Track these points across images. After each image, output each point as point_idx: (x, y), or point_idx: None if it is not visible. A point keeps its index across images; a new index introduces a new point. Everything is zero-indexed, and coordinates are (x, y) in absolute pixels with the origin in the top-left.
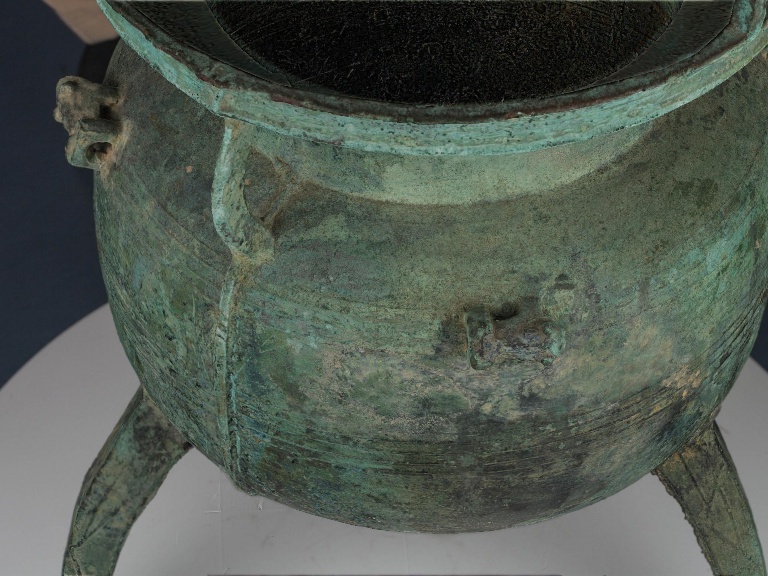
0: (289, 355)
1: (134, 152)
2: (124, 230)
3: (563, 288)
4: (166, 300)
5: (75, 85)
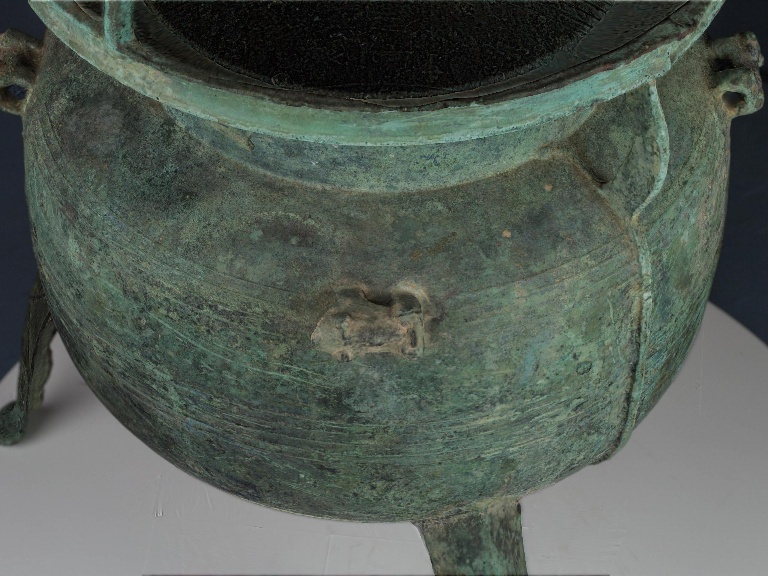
0: (684, 251)
1: (446, 287)
2: (496, 346)
3: None
4: (578, 340)
5: None
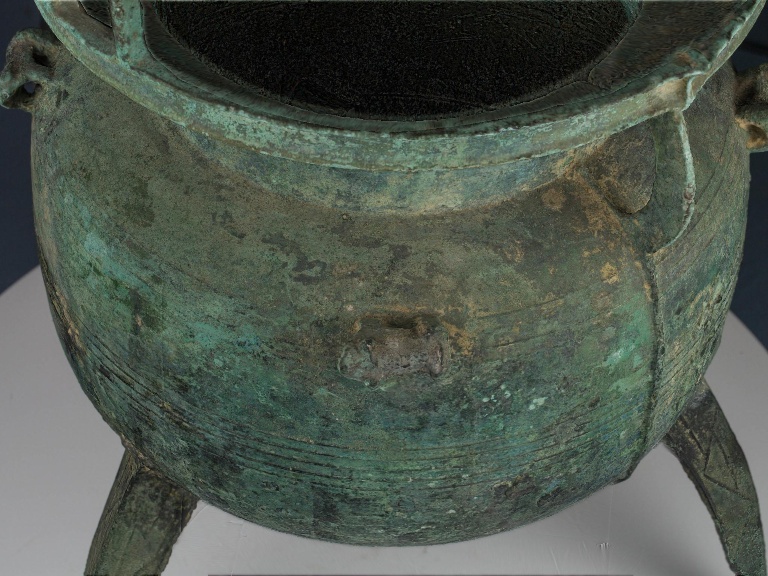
0: None
1: None
2: None
3: (58, 99)
4: None
5: None
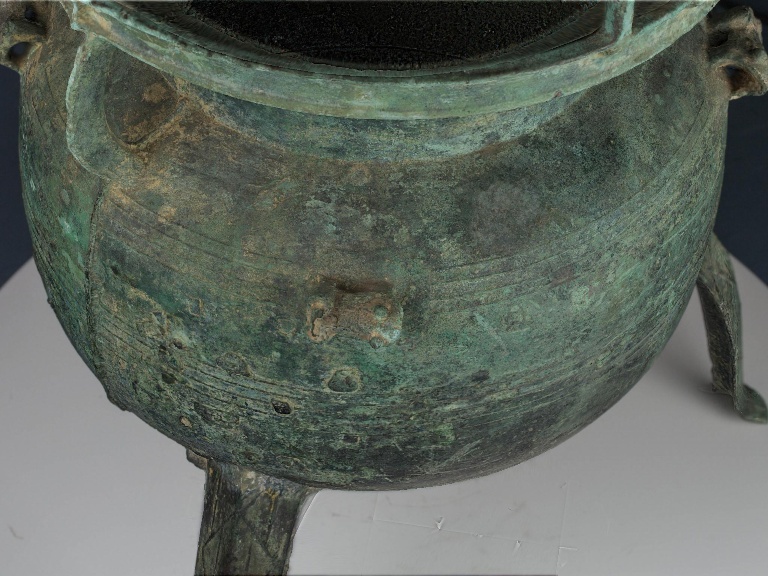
0: None
1: None
2: None
3: None
4: None
5: (752, 53)
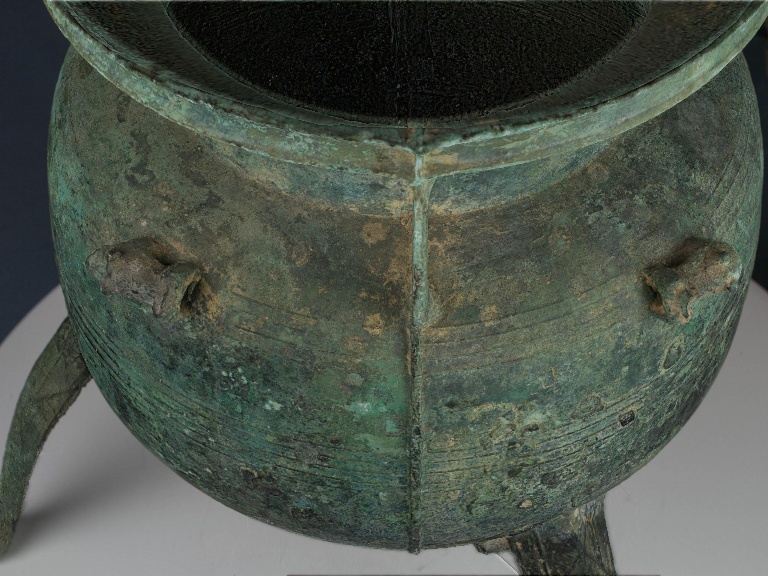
0: None
1: None
2: None
3: None
4: None
5: None
